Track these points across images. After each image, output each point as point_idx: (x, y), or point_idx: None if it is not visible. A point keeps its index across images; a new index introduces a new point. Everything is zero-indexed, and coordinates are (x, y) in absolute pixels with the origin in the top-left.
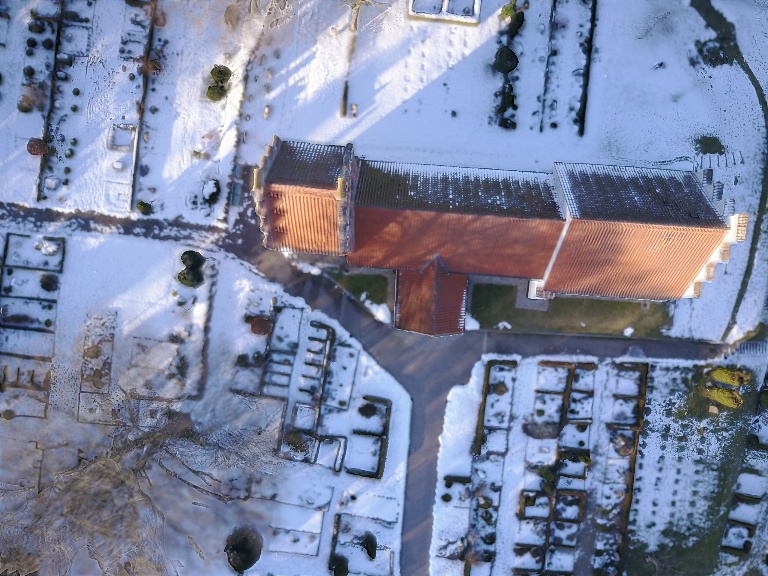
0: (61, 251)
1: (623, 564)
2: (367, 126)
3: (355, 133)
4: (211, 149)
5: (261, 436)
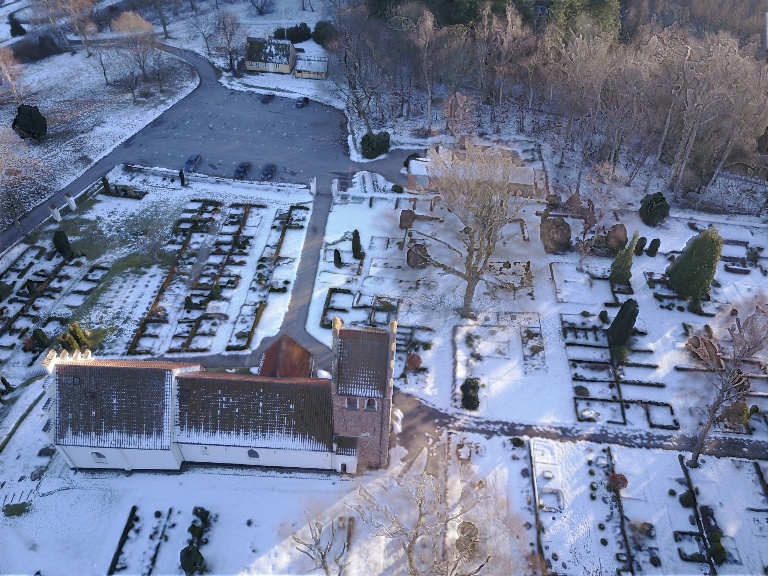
0: (579, 413)
1: (177, 259)
2: (330, 510)
3: (341, 504)
4: (470, 492)
5: (411, 309)
